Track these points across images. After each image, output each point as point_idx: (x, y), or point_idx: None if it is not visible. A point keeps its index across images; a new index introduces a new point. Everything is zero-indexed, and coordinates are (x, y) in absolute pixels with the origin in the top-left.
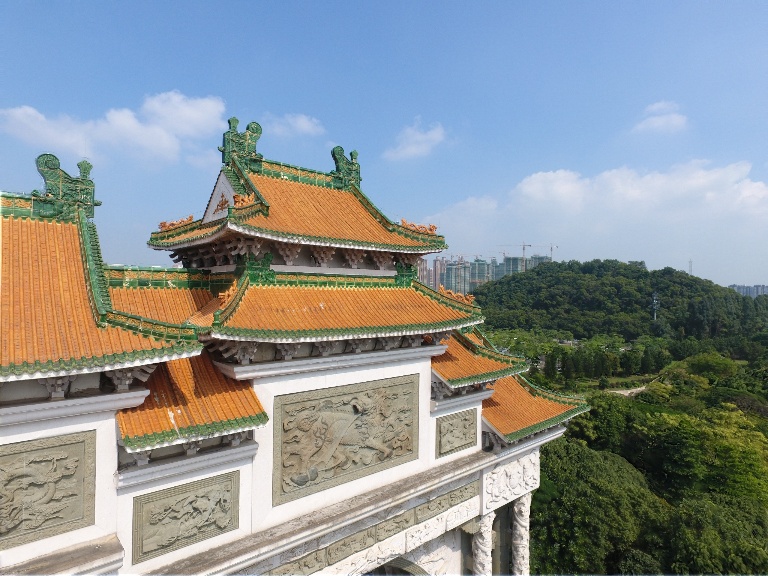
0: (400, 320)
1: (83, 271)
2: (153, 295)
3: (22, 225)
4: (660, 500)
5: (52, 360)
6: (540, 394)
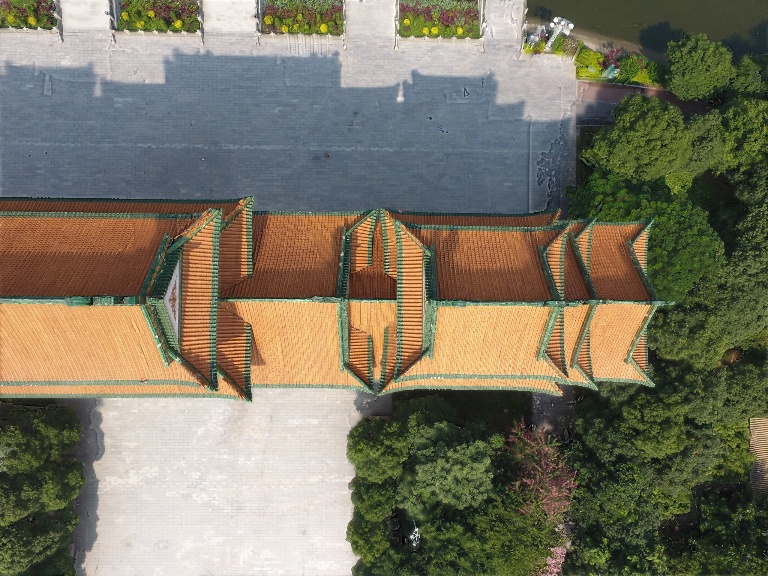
0: (496, 382)
1: (338, 335)
2: (377, 308)
3: (313, 305)
4: (765, 341)
5: (326, 383)
6: (631, 363)
